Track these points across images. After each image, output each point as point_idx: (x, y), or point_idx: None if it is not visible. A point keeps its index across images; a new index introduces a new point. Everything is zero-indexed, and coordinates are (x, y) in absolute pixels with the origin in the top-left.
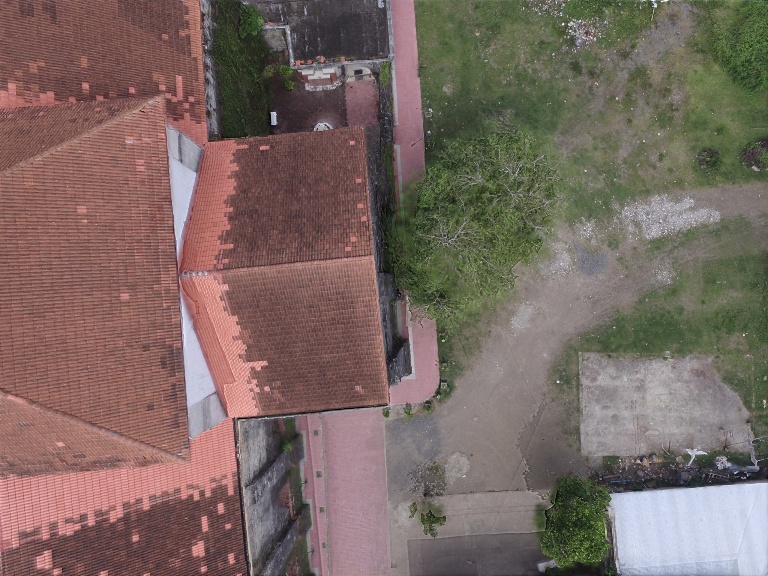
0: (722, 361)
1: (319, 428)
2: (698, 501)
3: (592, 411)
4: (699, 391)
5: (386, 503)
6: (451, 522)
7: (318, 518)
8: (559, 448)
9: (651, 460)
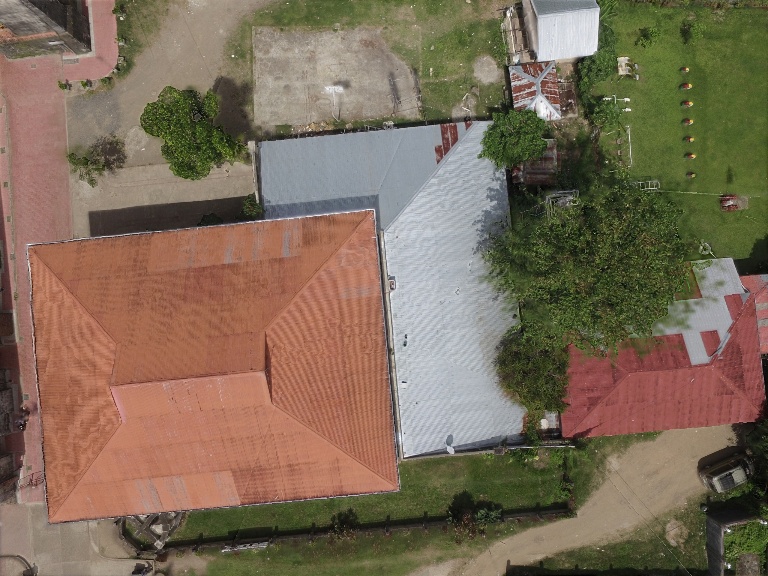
0: (390, 32)
1: (3, 106)
2: (347, 145)
3: (265, 82)
4: (368, 60)
5: (68, 177)
6: (130, 193)
7: (2, 193)
8: (234, 119)
9: (319, 125)
